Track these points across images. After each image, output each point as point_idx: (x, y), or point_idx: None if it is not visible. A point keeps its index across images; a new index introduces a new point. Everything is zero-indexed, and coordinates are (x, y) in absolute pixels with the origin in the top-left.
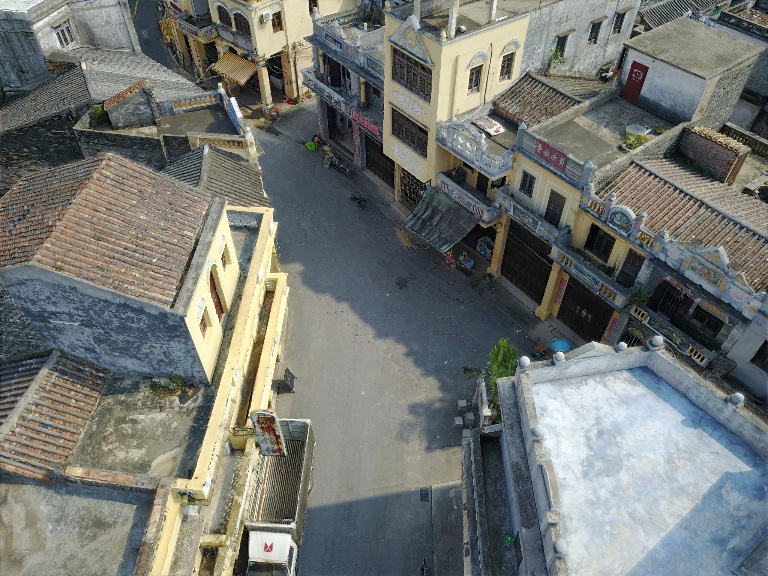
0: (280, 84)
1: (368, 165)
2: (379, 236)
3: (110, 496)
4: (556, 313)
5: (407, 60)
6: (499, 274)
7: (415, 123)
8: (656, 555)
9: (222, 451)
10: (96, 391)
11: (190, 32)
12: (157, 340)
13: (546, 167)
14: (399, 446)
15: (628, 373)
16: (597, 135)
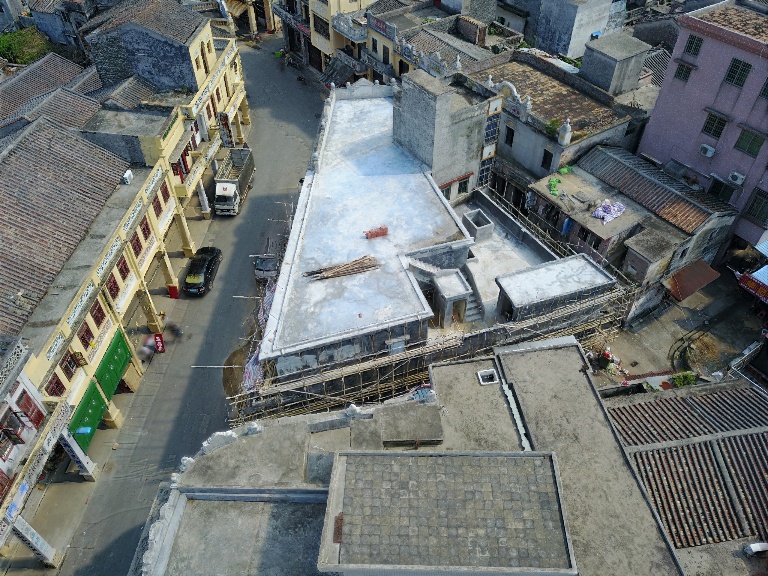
0: (264, 22)
1: (311, 63)
2: (310, 96)
3: (157, 115)
4: None
5: None
6: None
7: (323, 20)
8: (366, 139)
9: None
10: (152, 91)
11: None
12: (178, 63)
13: (379, 32)
14: (300, 175)
15: (383, 98)
16: (412, 21)
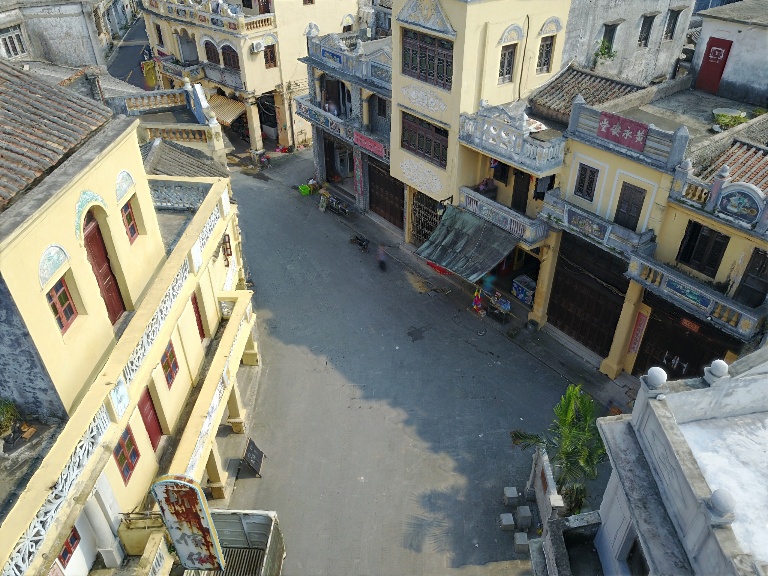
0: (274, 133)
1: (372, 206)
2: (385, 281)
3: None
4: (631, 367)
5: (421, 41)
6: (544, 321)
7: (431, 124)
8: None
9: (57, 546)
10: None
11: (174, 73)
12: None
13: (615, 150)
14: (416, 560)
15: None
16: (675, 120)
